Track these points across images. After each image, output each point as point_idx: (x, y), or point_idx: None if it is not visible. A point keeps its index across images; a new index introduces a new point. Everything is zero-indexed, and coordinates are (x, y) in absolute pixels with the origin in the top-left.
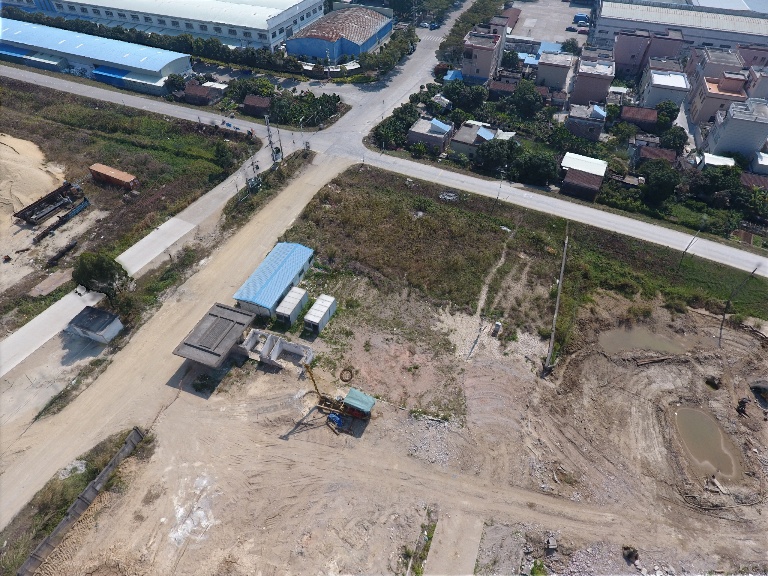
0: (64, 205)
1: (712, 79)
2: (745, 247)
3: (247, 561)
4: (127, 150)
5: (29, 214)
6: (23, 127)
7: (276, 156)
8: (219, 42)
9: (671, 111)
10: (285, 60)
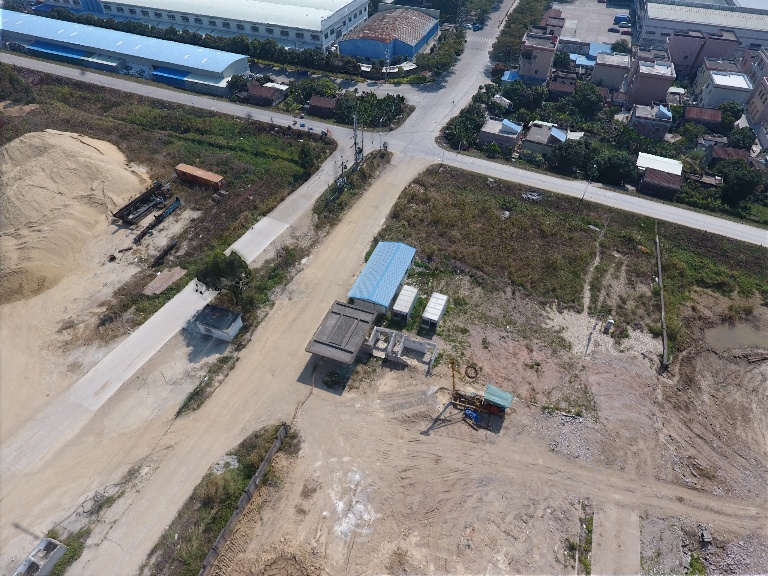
0: (156, 205)
1: None
2: None
3: (416, 553)
4: (205, 150)
5: (126, 214)
6: (98, 128)
7: (358, 156)
8: (276, 43)
9: (736, 111)
10: (344, 61)
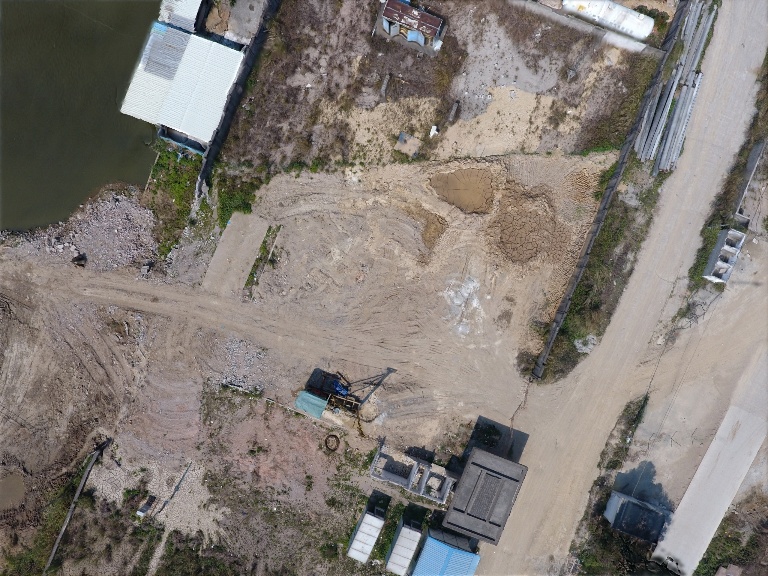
0: None
1: None
2: None
3: (409, 262)
4: None
5: None
6: None
7: None
8: None
9: None
10: None
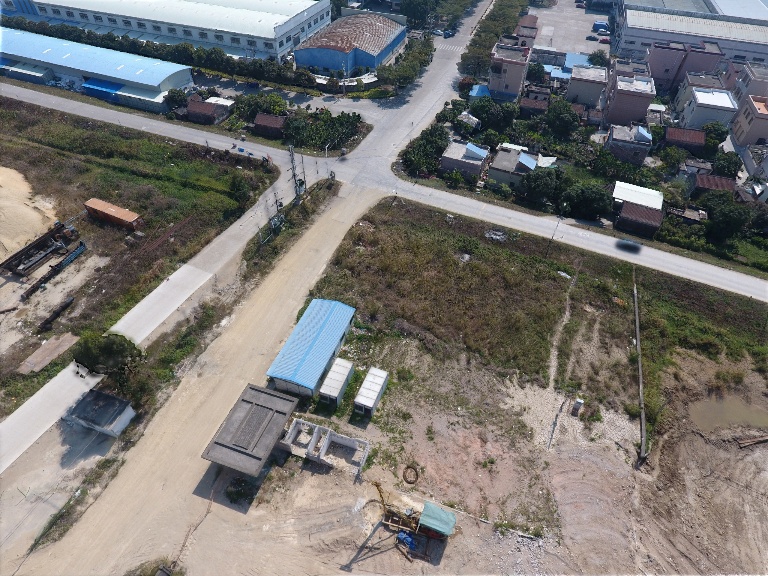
0: (56, 250)
1: (758, 98)
2: None
3: None
4: (127, 180)
5: (15, 264)
6: (5, 152)
7: (299, 189)
8: (222, 52)
9: (720, 133)
10: (297, 73)
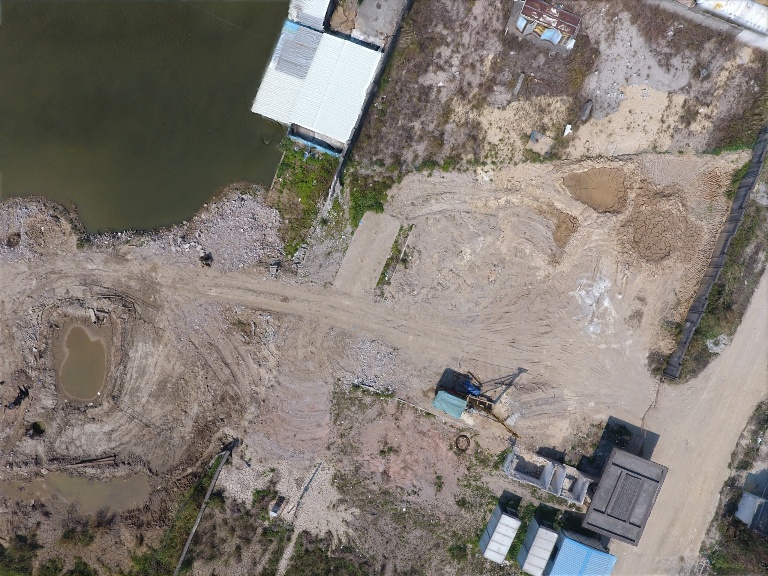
0: None
1: None
2: None
3: (540, 262)
4: None
5: None
6: None
7: None
8: None
9: None
10: None
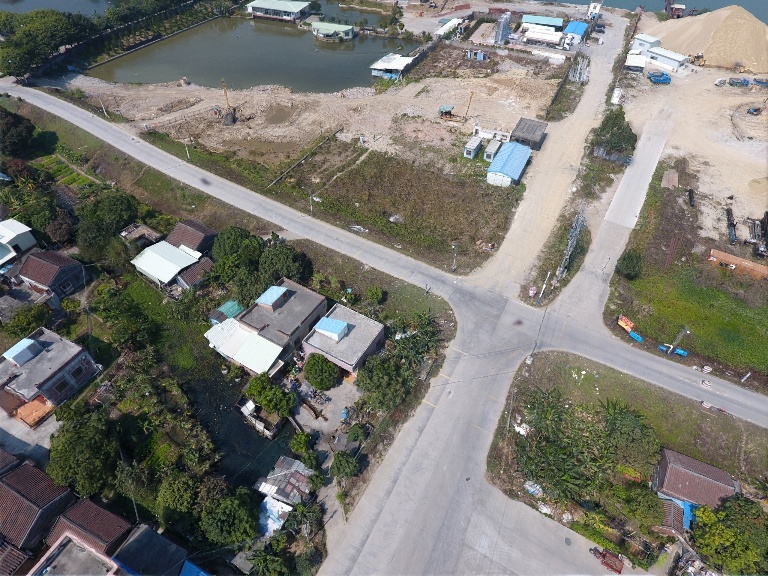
0: None
1: None
2: (122, 174)
3: (483, 95)
4: None
5: None
6: None
7: None
8: None
9: None
10: None
